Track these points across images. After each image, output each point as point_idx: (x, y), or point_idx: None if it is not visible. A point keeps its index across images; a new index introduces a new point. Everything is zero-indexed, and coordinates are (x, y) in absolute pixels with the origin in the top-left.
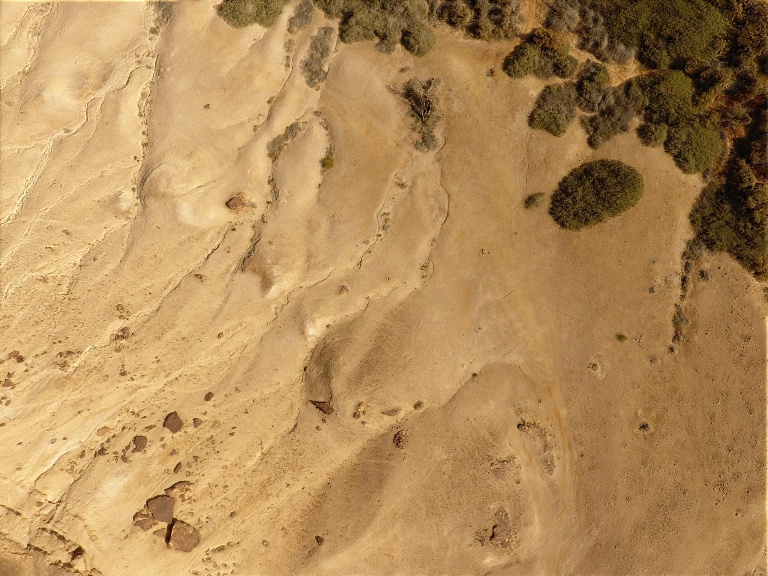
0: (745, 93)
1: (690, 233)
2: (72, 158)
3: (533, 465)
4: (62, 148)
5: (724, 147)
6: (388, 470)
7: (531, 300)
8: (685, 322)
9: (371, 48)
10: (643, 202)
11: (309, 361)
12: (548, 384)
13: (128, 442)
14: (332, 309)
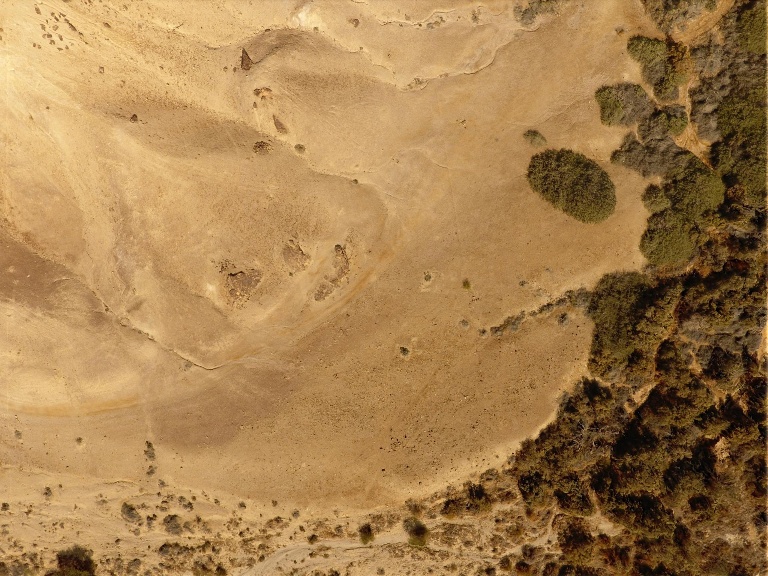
0: (741, 251)
1: (592, 285)
2: None
3: (314, 278)
4: None
5: (683, 267)
6: (230, 149)
7: (449, 188)
8: (514, 327)
9: None
10: (592, 228)
11: (276, 30)
12: (389, 249)
13: None
14: (332, 21)
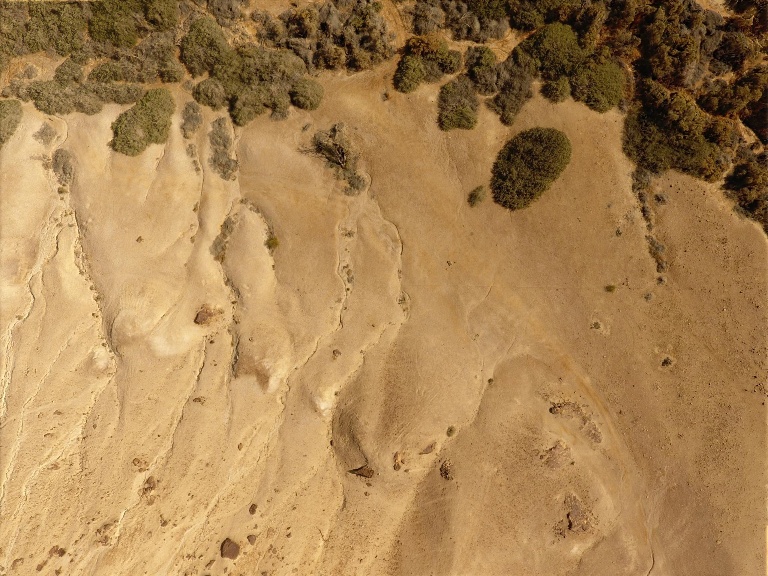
0: (624, 18)
1: (630, 165)
2: (35, 341)
3: (579, 440)
4: (22, 335)
5: (627, 74)
6: (447, 505)
7: (512, 289)
8: (661, 249)
9: (267, 121)
10: (575, 156)
11: (332, 434)
12: (561, 359)
13: None
14: (333, 377)
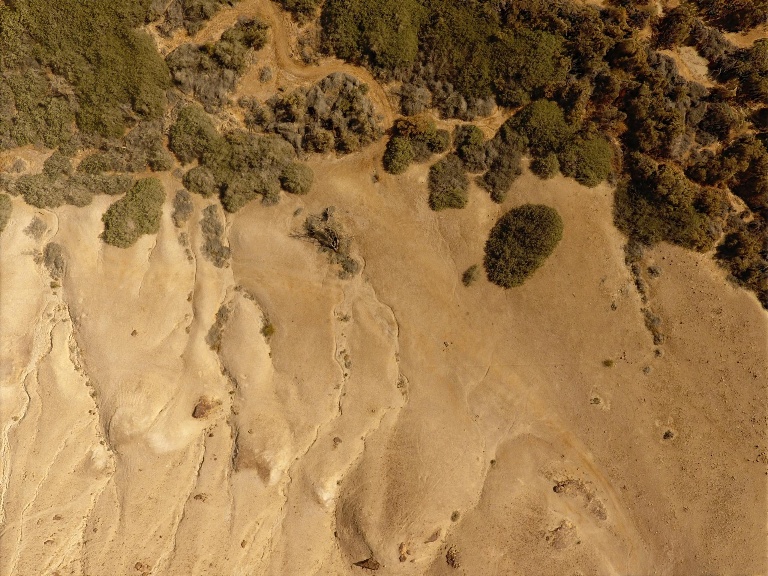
0: (609, 93)
1: (622, 239)
2: (32, 442)
3: (585, 519)
4: (18, 438)
5: (614, 148)
6: None
7: (510, 368)
8: (657, 321)
9: (258, 206)
10: (567, 232)
11: (336, 525)
12: (562, 436)
13: None
14: (334, 466)
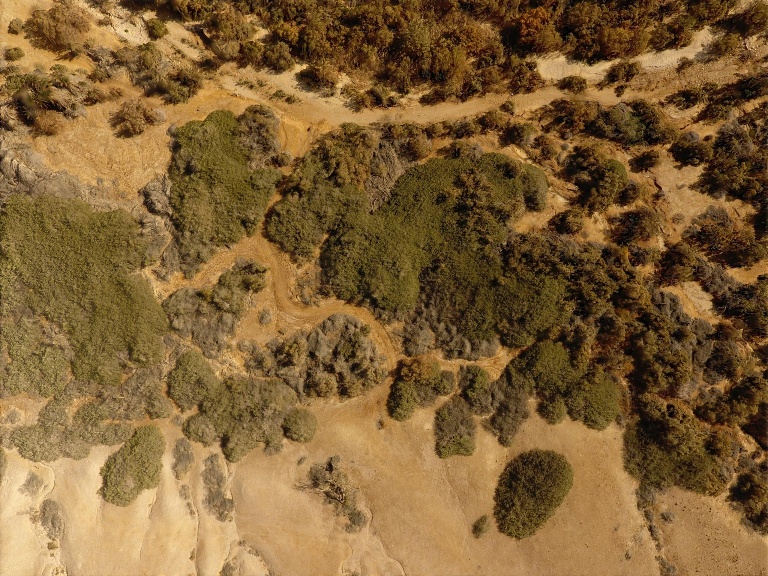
0: (615, 336)
1: (633, 483)
2: None
3: None
4: None
5: (622, 388)
6: None
7: None
8: (672, 570)
9: (261, 455)
10: (577, 479)
11: None
12: None
13: None
14: None
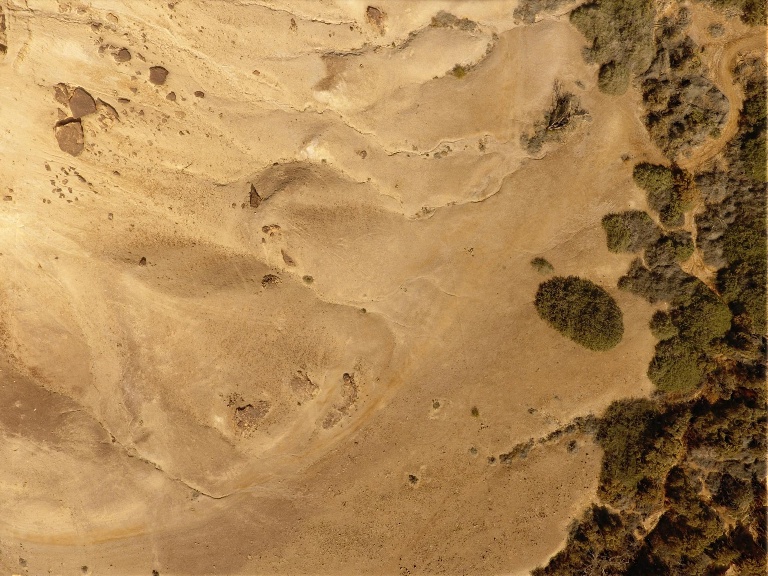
0: (748, 380)
1: (600, 412)
2: None
3: (322, 407)
4: None
5: (691, 393)
6: (238, 285)
7: (457, 316)
8: (523, 455)
9: (580, 45)
10: (601, 355)
11: (284, 163)
12: (397, 376)
13: (117, 45)
14: (340, 154)
